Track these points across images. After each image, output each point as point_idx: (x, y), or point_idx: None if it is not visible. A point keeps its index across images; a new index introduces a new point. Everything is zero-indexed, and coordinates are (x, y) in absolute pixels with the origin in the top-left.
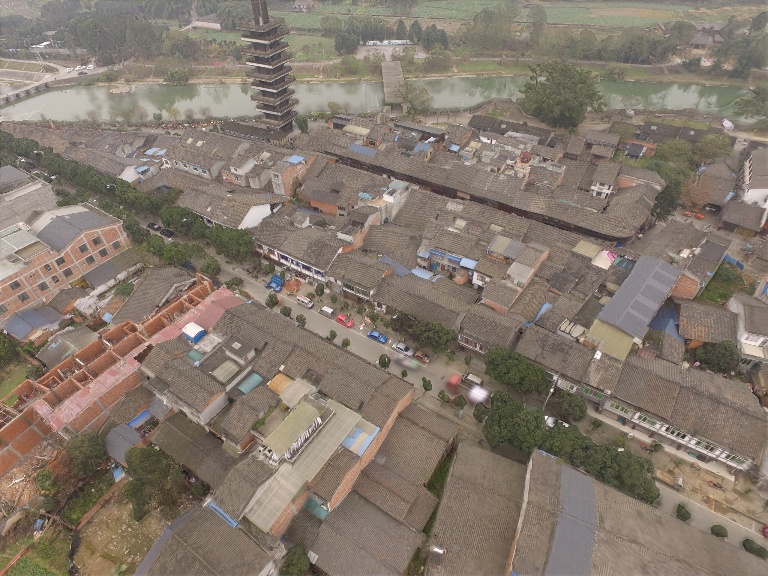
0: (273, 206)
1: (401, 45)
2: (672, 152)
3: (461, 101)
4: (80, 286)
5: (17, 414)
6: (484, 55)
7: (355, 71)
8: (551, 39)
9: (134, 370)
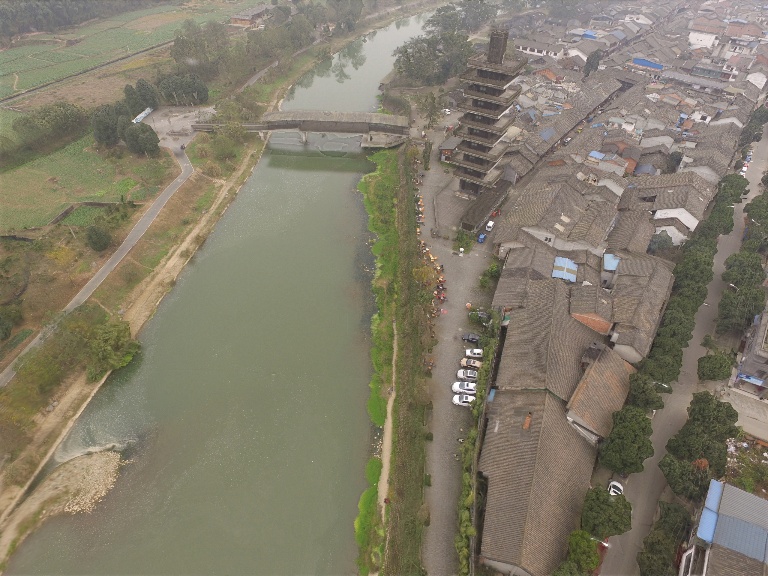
0: None
1: (149, 117)
2: None
3: None
4: None
5: None
6: (230, 85)
7: (232, 153)
8: (269, 45)
9: None
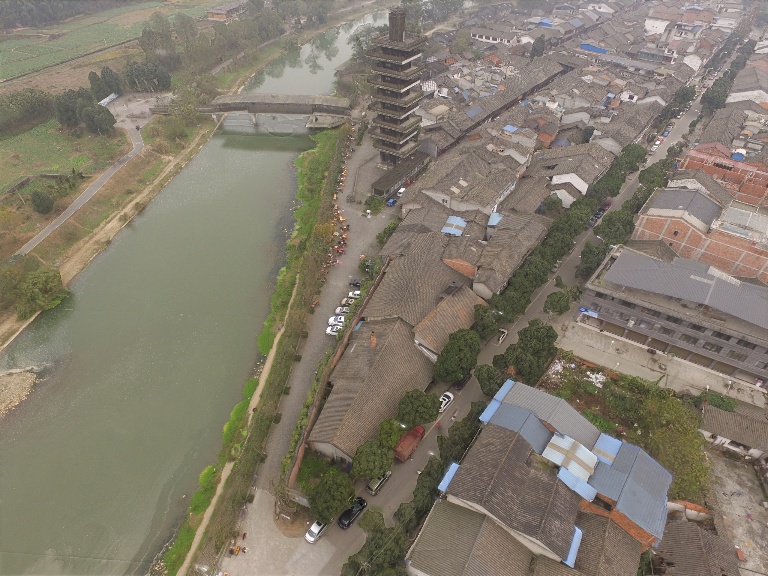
0: None
1: (113, 102)
2: (465, 45)
3: None
4: None
5: None
6: None
7: (183, 133)
8: (235, 36)
9: None
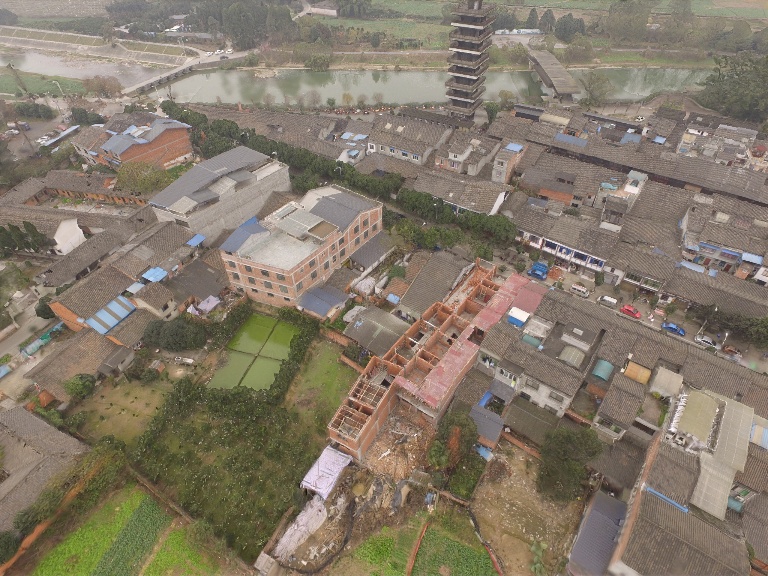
0: (506, 194)
1: (531, 34)
2: None
3: (619, 93)
4: (346, 266)
5: (386, 389)
6: (622, 46)
7: (496, 60)
8: (701, 30)
9: (476, 351)
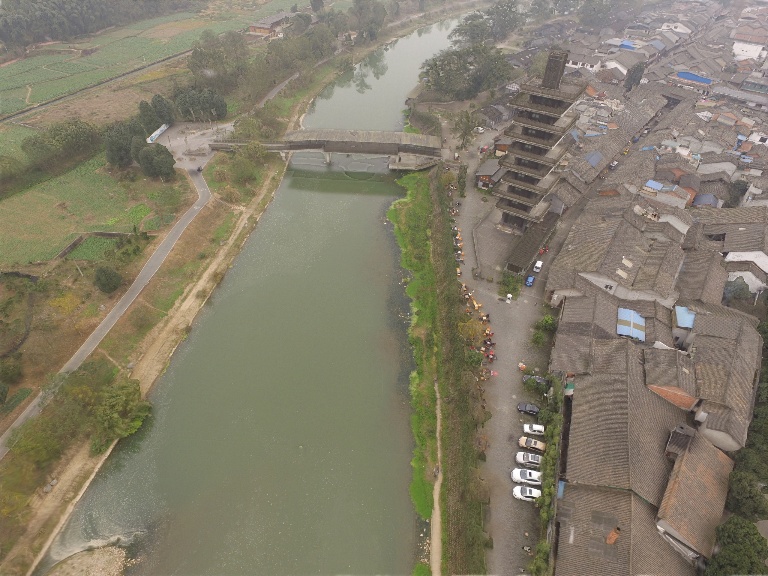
0: None
1: (164, 134)
2: None
3: (378, 129)
4: None
5: None
6: (249, 99)
7: (252, 175)
8: (289, 56)
9: None
